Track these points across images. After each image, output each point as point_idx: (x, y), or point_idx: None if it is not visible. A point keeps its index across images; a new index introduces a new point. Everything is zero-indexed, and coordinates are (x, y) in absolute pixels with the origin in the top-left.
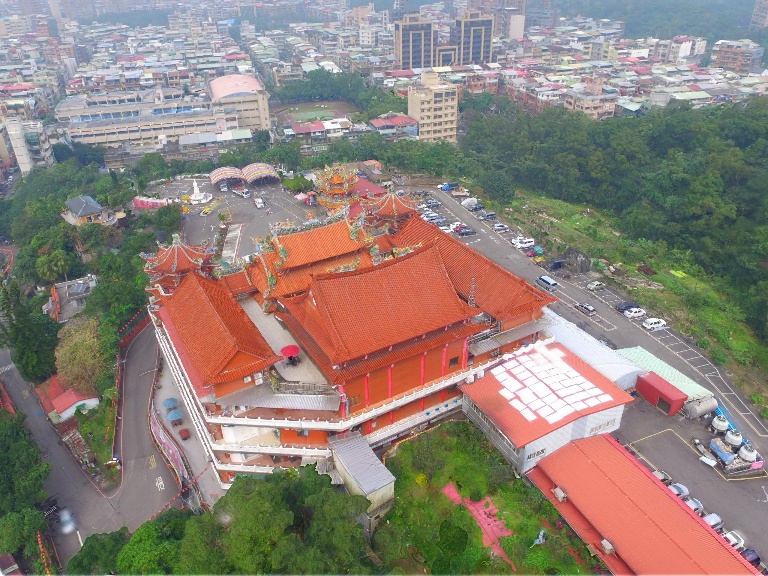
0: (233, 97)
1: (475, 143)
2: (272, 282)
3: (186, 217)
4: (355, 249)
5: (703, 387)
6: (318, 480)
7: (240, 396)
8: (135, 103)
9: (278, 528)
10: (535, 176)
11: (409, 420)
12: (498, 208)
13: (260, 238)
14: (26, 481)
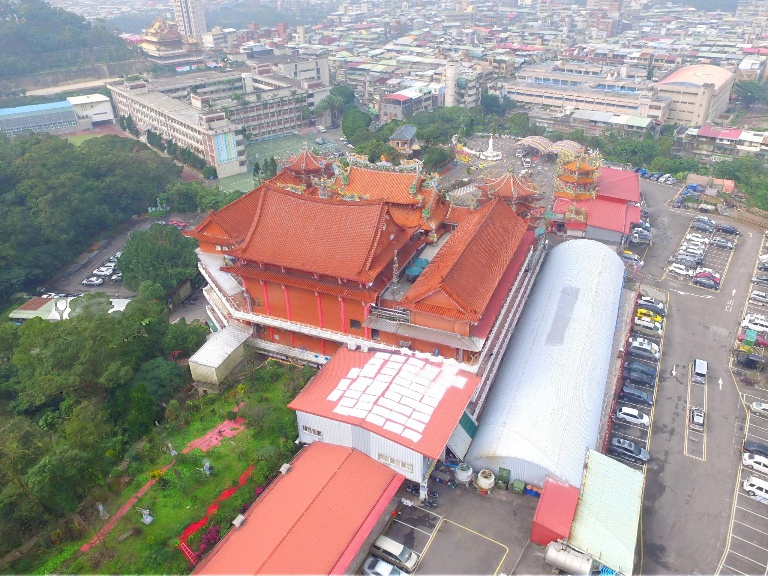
0: (674, 85)
1: None
2: None
3: (460, 165)
4: (405, 202)
5: (632, 559)
6: (186, 334)
7: (211, 258)
8: None
9: (78, 314)
10: None
11: None
12: None
13: None
14: (173, 270)
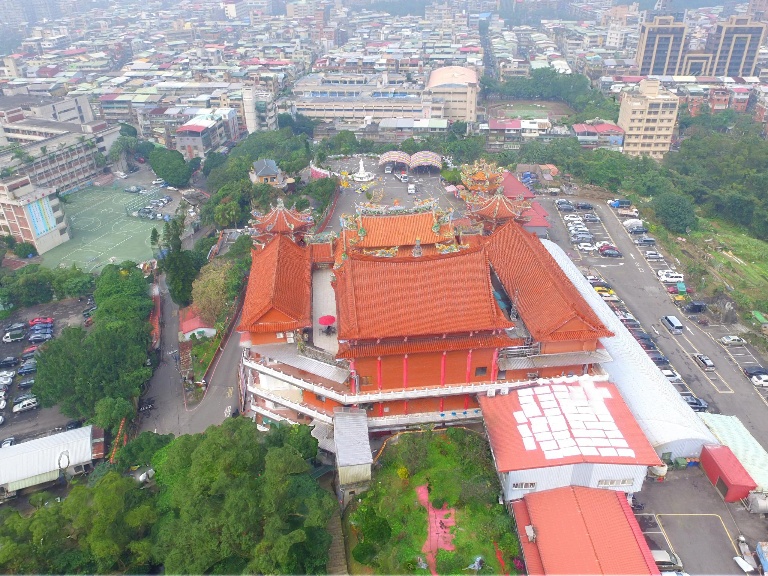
0: (444, 87)
1: (682, 162)
2: (346, 257)
3: (344, 191)
4: (433, 242)
5: None
6: (305, 440)
7: (271, 348)
8: (360, 85)
9: (223, 461)
10: (740, 209)
11: (422, 415)
12: (662, 235)
13: (345, 215)
14: (129, 377)
